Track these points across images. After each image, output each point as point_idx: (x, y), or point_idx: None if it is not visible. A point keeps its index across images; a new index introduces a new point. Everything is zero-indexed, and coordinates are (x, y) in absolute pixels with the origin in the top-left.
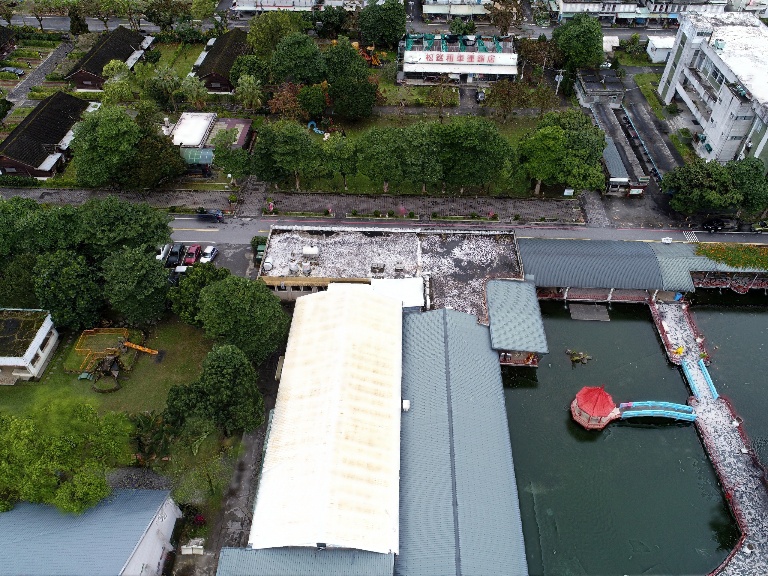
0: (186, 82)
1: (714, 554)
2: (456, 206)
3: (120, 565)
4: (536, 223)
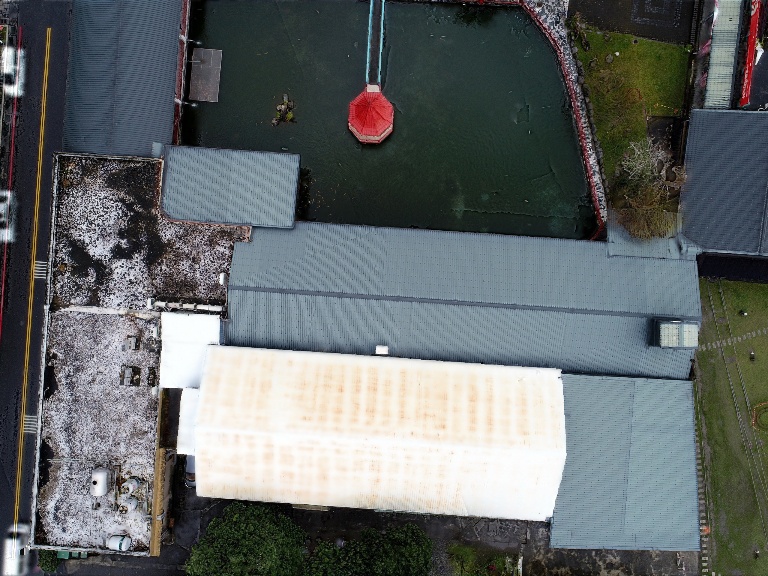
0: None
1: (531, 41)
2: None
3: None
4: (4, 106)
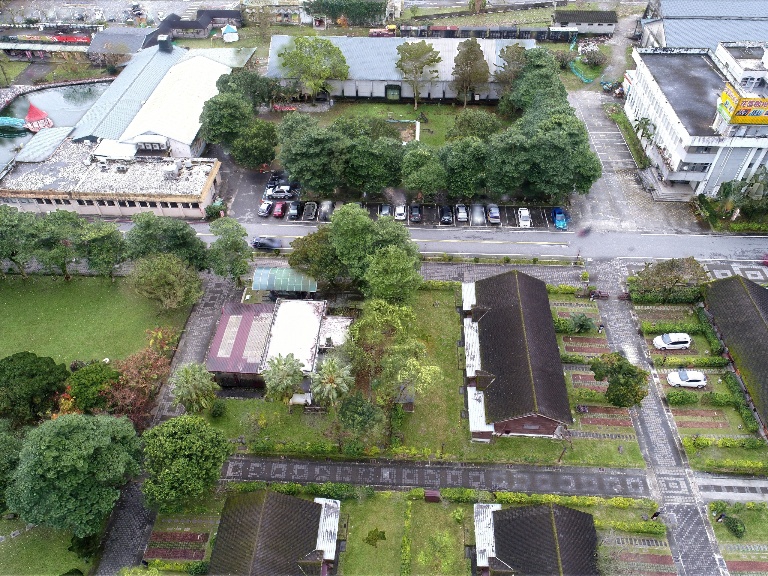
0: (294, 359)
1: None
2: (5, 262)
3: (273, 41)
4: None
